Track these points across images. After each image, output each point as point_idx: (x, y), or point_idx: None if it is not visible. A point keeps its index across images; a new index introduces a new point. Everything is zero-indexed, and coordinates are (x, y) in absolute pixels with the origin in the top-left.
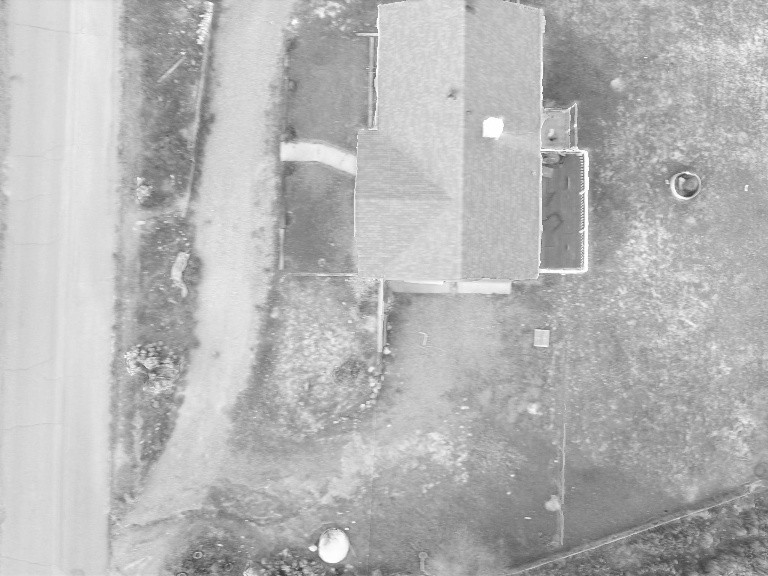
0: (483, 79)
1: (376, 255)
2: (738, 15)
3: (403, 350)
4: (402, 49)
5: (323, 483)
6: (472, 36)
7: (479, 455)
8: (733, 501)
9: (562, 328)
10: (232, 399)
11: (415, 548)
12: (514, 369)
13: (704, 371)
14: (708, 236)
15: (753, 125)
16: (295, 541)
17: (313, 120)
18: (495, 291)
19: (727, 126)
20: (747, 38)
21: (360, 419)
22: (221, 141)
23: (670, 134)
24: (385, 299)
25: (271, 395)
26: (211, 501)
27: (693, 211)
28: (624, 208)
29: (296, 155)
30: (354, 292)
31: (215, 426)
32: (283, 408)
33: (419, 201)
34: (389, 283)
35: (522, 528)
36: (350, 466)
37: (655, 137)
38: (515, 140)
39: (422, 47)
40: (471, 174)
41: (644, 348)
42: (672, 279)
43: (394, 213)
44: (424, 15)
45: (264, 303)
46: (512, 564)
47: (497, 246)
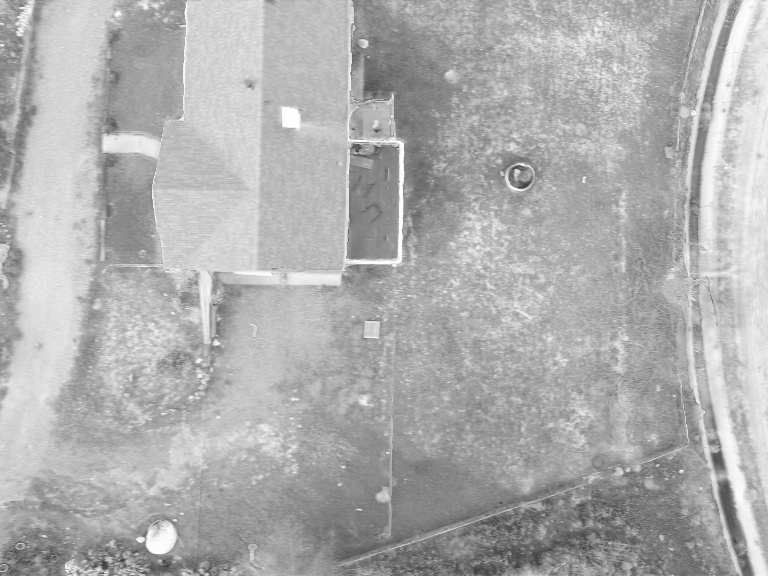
0: (283, 69)
1: (179, 245)
2: (577, 7)
3: (233, 342)
4: (207, 40)
5: (151, 474)
6: (271, 26)
7: (309, 447)
8: (569, 493)
9: (393, 320)
10: (56, 390)
11: (244, 539)
12: (344, 361)
13: (540, 363)
14: (544, 228)
15: (592, 117)
16: (122, 532)
17: (134, 112)
18: (325, 283)
19: (565, 118)
20: (586, 30)
21: (189, 411)
22: (43, 133)
23: (505, 126)
24: (214, 291)
25: (95, 386)
26: (34, 492)
27: (529, 203)
28: (458, 200)
29: (118, 147)
30: (175, 283)
31: (39, 417)
32: (108, 399)
33: (217, 191)
34: (219, 275)
35: (353, 520)
36: (178, 457)
37: (490, 129)
38: (319, 130)
39: (225, 38)
40: (269, 164)
41: (478, 340)
42: (507, 271)
43: (193, 203)
44: (227, 6)
45: (86, 294)
46: (343, 556)
47: (298, 236)
